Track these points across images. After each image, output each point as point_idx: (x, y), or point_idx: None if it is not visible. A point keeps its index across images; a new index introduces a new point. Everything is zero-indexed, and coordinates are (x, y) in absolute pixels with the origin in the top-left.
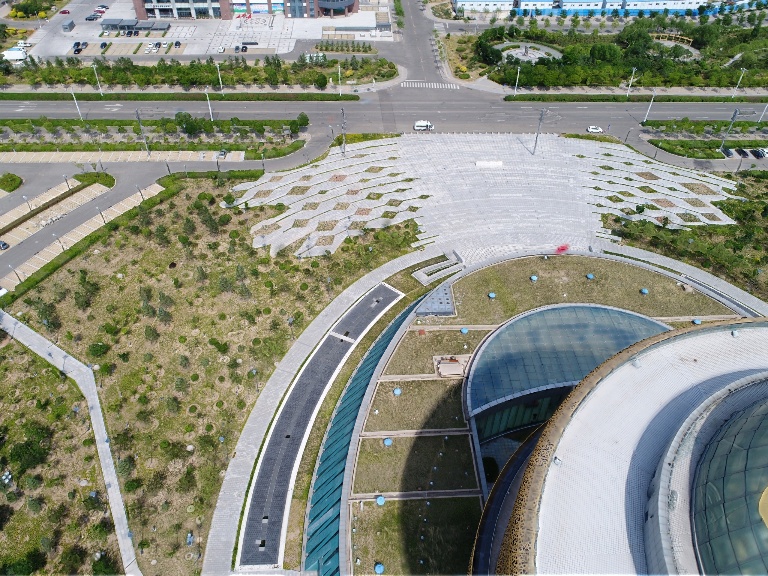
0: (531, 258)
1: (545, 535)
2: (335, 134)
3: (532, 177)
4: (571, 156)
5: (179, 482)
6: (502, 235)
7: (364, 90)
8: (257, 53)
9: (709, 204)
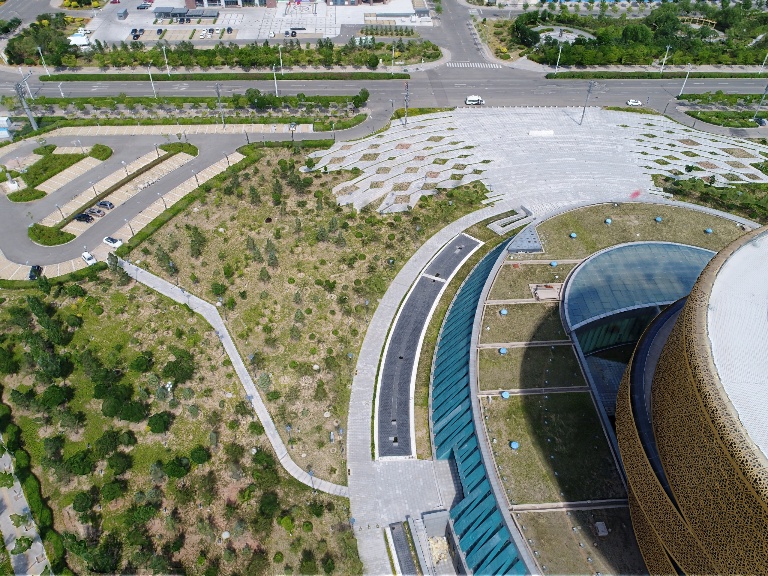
0: (603, 205)
1: (714, 352)
2: (393, 109)
3: (582, 144)
4: (616, 126)
5: (313, 394)
6: (563, 193)
7: (413, 70)
8: (306, 37)
9: (749, 166)
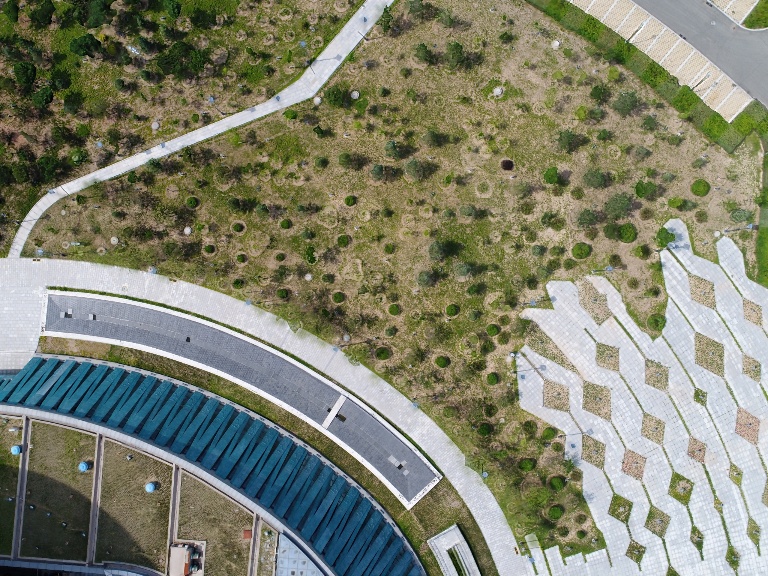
0: None
1: None
2: None
3: None
4: None
5: None
6: None
7: None
8: None
9: None
